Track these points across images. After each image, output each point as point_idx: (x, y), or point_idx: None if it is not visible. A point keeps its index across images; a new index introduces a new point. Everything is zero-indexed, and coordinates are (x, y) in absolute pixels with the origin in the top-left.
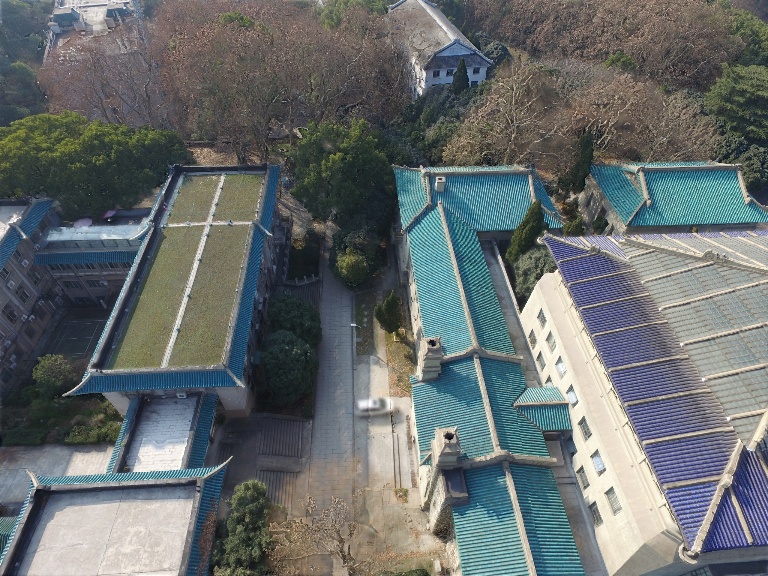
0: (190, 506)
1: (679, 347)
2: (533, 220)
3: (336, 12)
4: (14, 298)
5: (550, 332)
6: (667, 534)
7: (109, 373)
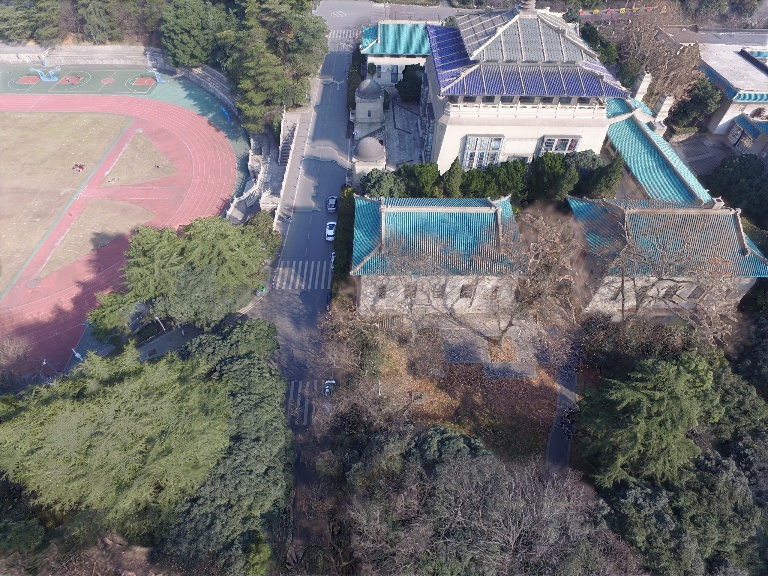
0: None
1: None
2: None
3: None
4: None
5: None
6: None
7: None
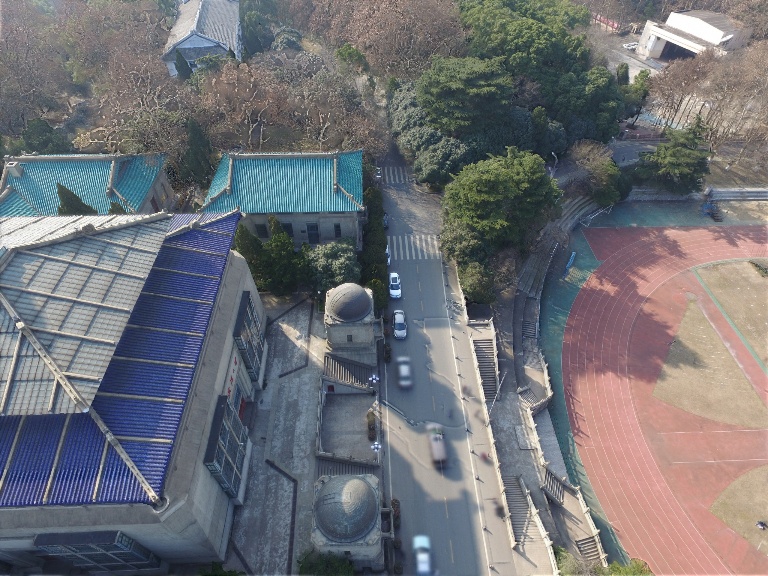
0: None
1: None
2: (63, 204)
3: (99, 5)
4: None
5: None
6: None
7: None
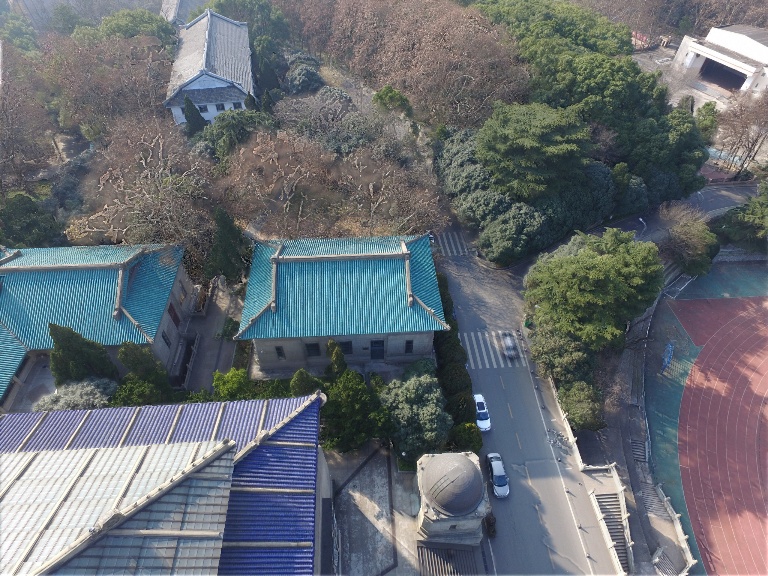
0: None
1: None
2: (57, 347)
3: (88, 36)
4: None
5: None
6: None
7: None
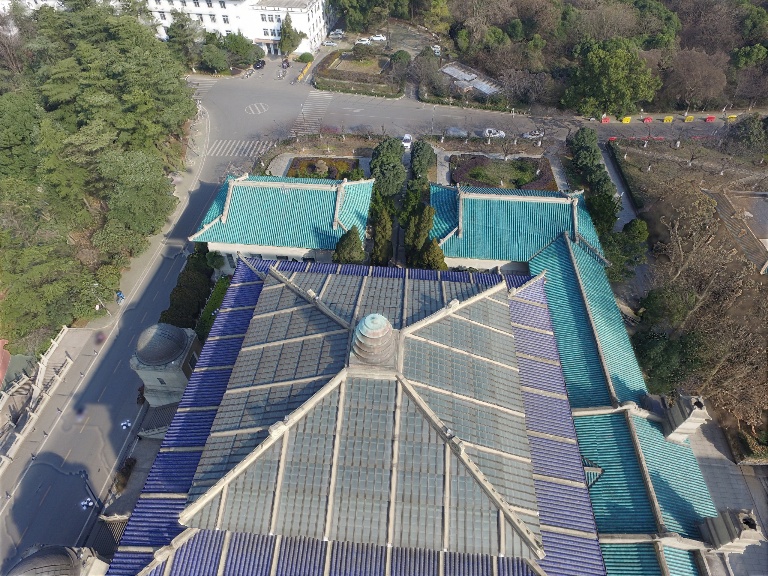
0: None
1: None
2: None
3: None
4: None
5: None
6: None
7: None
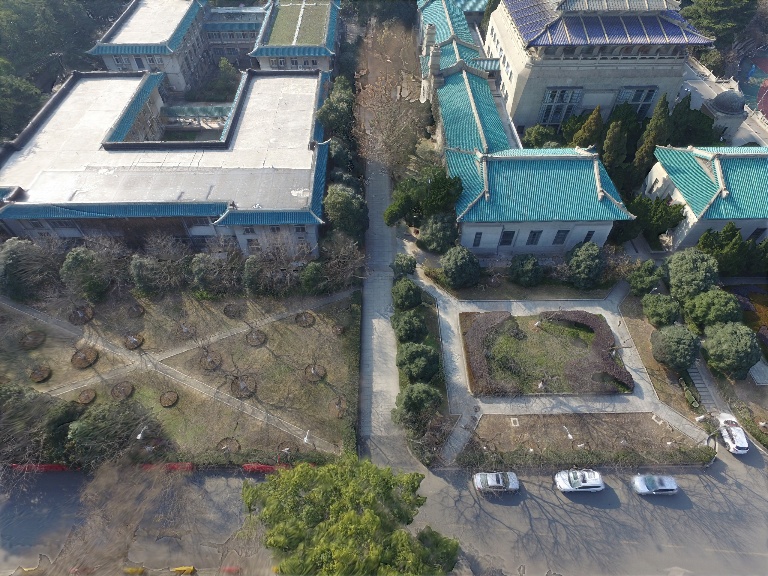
0: (316, 80)
1: (544, 1)
2: None
3: None
4: (196, 42)
5: (495, 33)
6: (527, 66)
7: (267, 46)
